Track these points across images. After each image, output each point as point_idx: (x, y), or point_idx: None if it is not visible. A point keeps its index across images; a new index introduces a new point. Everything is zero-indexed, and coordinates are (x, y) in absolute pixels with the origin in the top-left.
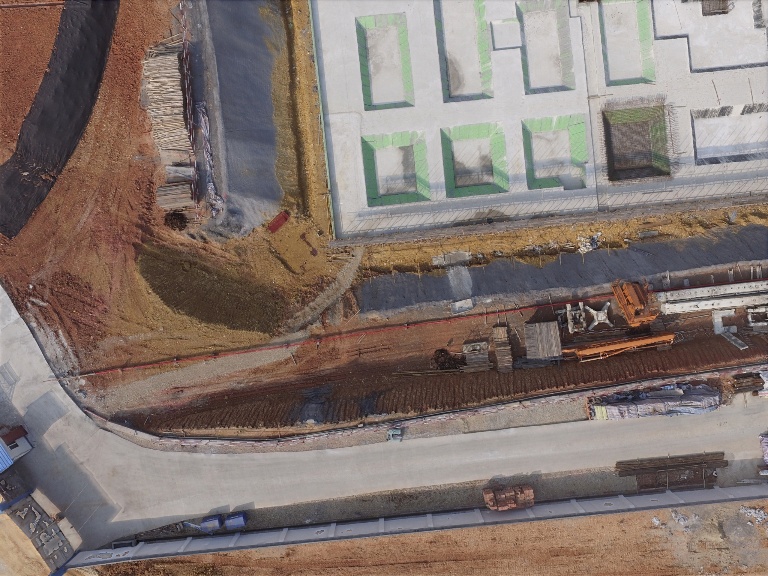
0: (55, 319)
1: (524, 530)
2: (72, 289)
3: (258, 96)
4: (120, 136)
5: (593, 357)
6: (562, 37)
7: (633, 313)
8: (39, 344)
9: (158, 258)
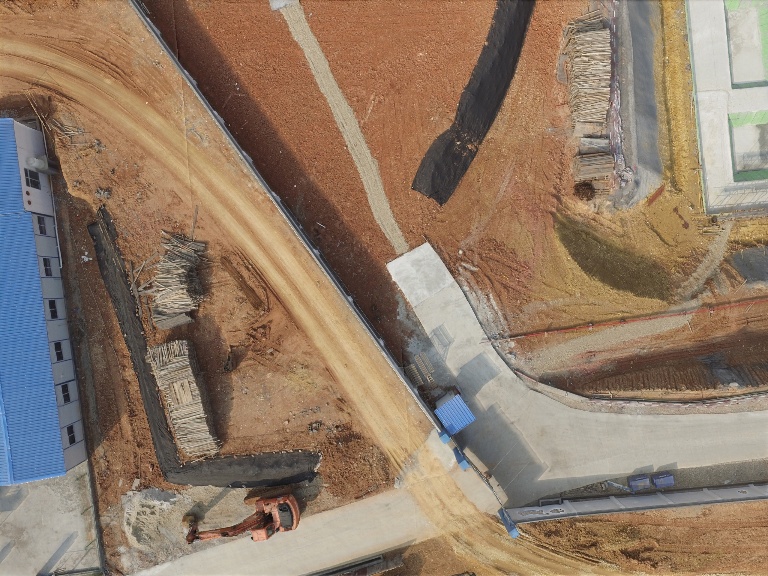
0: (486, 283)
1: None
2: (499, 255)
3: (648, 73)
4: (535, 109)
5: None
6: None
7: None
8: (472, 307)
9: (565, 227)
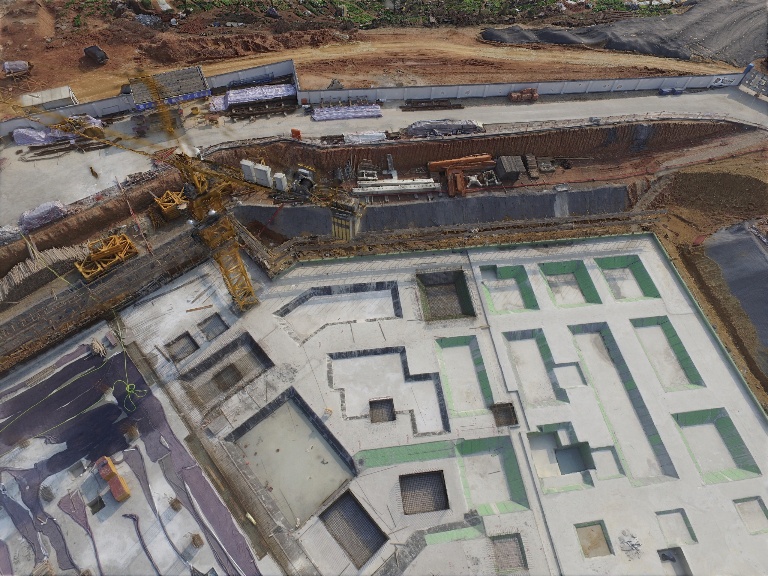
0: None
1: None
2: None
3: (760, 310)
4: None
5: None
6: None
7: None
8: None
9: None
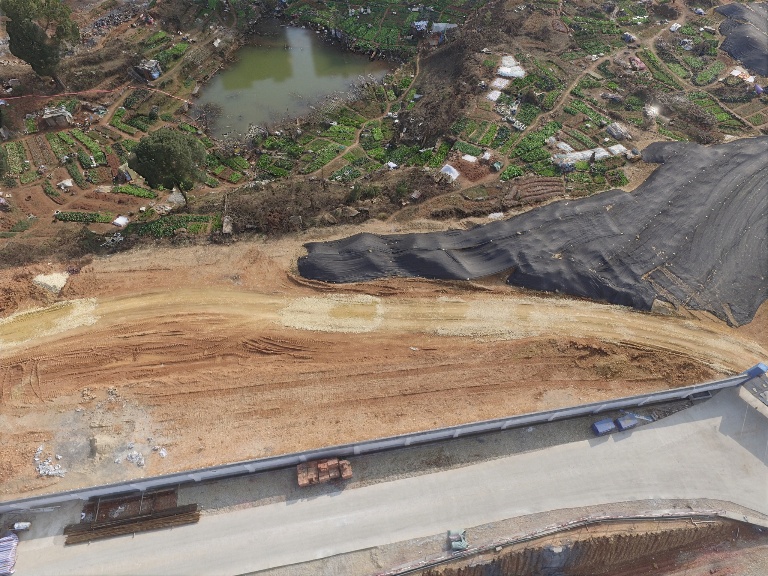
0: None
1: (306, 434)
2: None
3: None
4: None
5: None
6: None
7: None
8: None
9: None
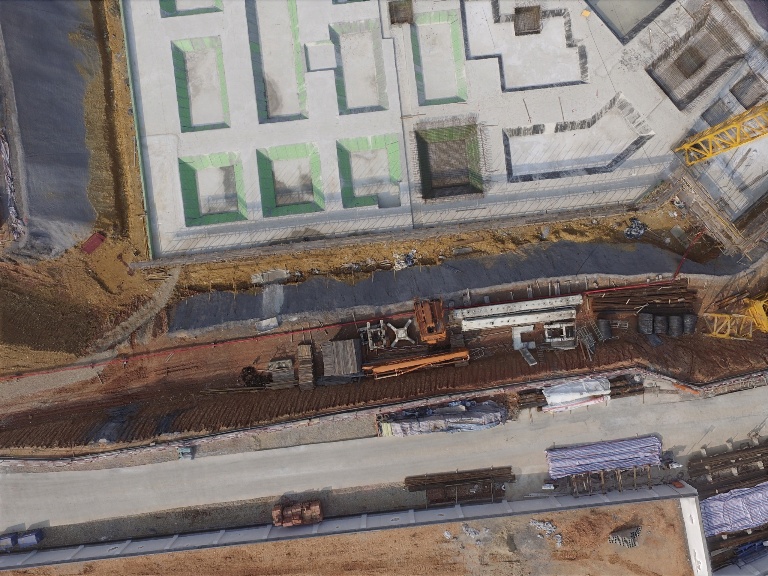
0: None
1: (318, 545)
2: None
3: (67, 120)
4: None
5: (388, 374)
6: (377, 58)
7: (426, 331)
8: None
9: None
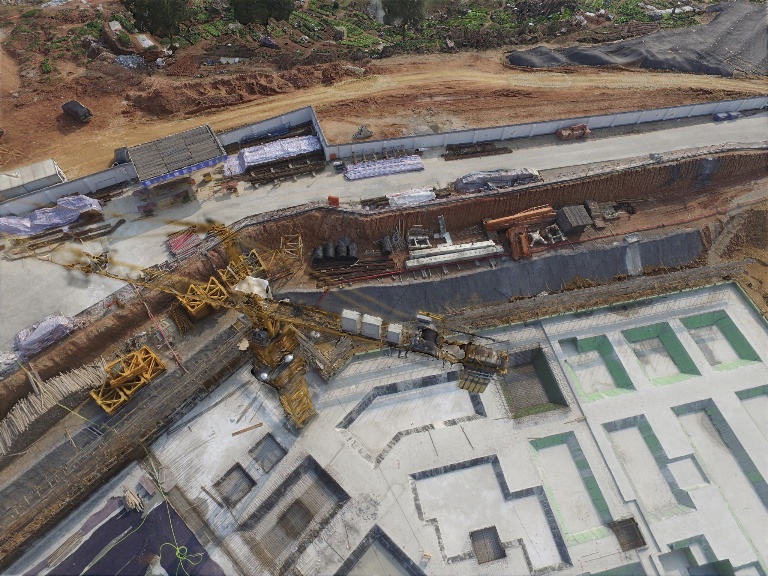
0: None
1: None
2: None
3: None
4: None
5: None
6: (631, 481)
7: None
8: None
9: None
